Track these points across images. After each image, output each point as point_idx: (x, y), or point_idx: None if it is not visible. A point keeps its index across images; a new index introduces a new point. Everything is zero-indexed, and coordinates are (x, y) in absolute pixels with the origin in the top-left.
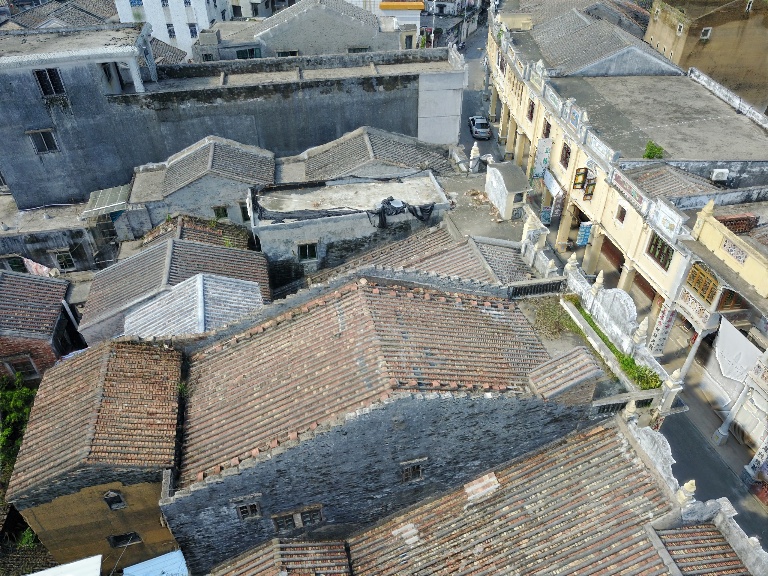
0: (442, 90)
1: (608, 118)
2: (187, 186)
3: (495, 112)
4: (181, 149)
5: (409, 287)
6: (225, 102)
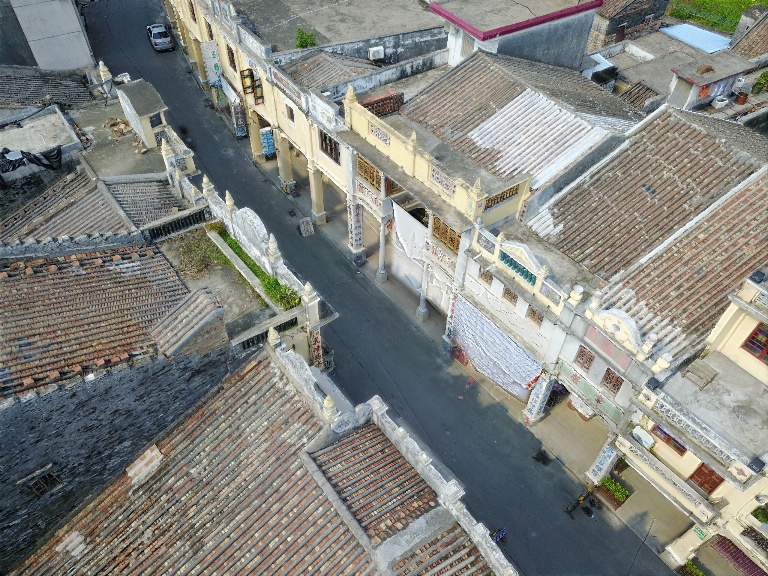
0: (44, 2)
1: (266, 8)
2: None
3: (174, 17)
4: None
5: (3, 265)
6: None
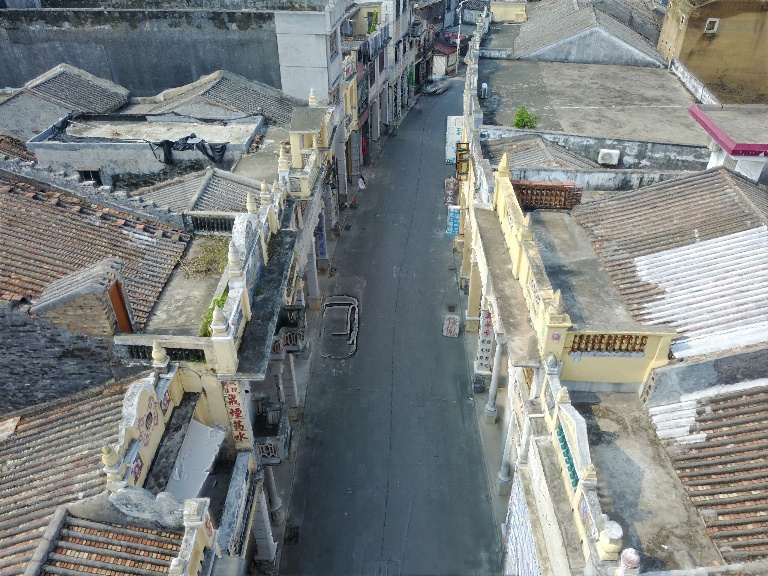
0: (303, 34)
1: (526, 96)
2: (6, 104)
3: None
4: (37, 76)
5: (42, 189)
6: (73, 27)
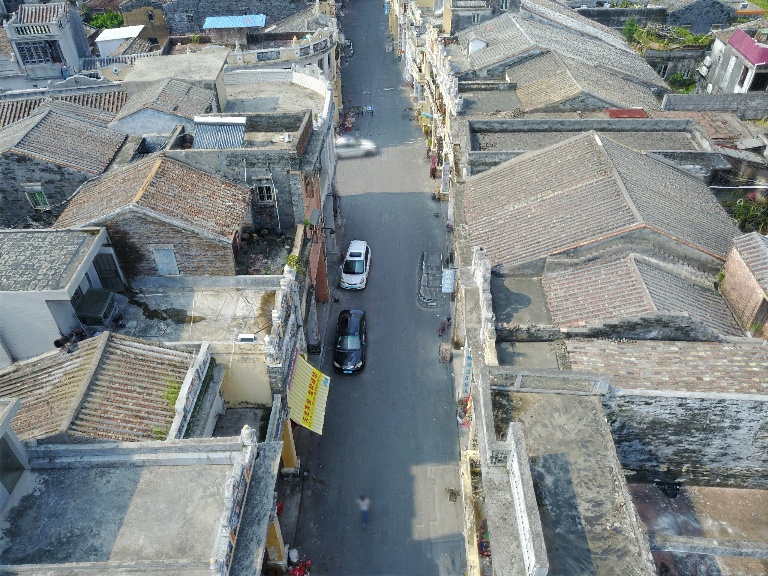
0: None
1: None
2: None
3: None
4: None
5: None
6: None
